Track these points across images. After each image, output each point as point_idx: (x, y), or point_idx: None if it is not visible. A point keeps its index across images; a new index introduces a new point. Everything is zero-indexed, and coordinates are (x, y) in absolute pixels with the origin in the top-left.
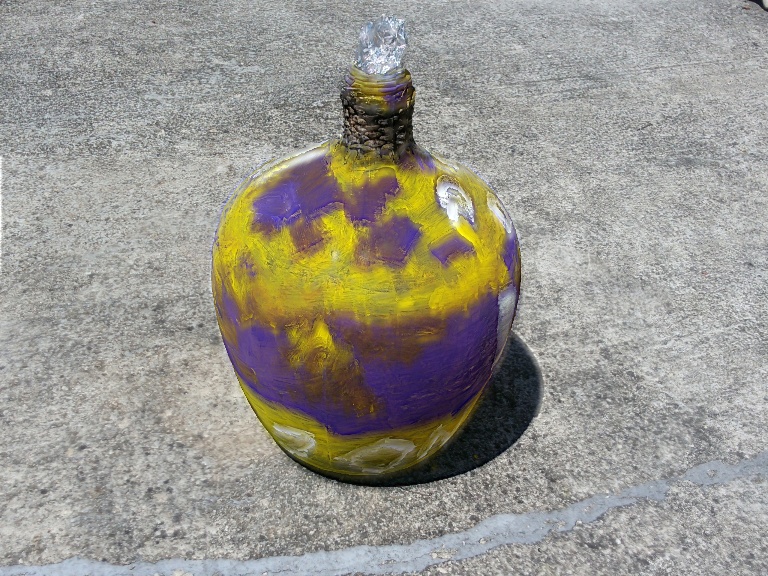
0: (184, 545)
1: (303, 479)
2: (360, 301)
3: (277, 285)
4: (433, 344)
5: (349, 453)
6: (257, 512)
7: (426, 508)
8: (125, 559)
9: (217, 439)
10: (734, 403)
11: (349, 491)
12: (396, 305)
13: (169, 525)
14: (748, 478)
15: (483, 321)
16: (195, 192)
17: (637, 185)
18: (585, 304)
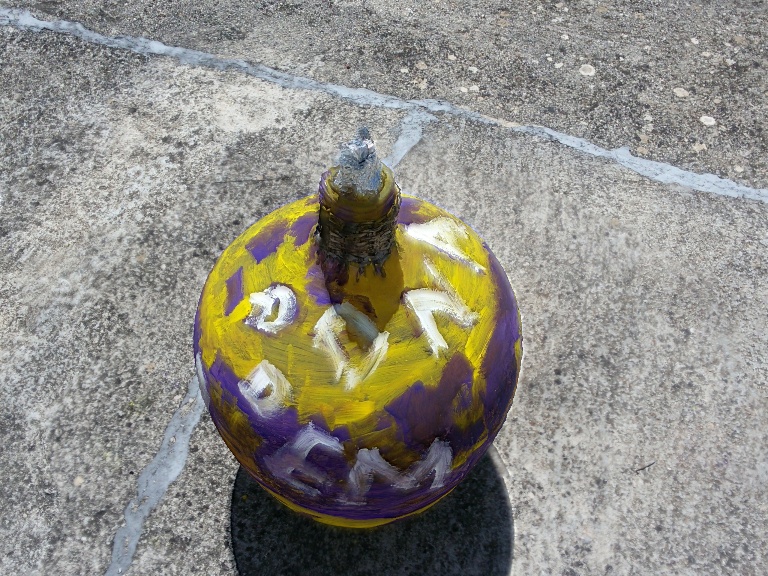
0: None
1: None
2: None
3: None
4: None
5: None
6: None
7: None
8: None
9: None
10: None
11: None
12: None
13: None
14: None
15: None
16: None
17: None
18: None
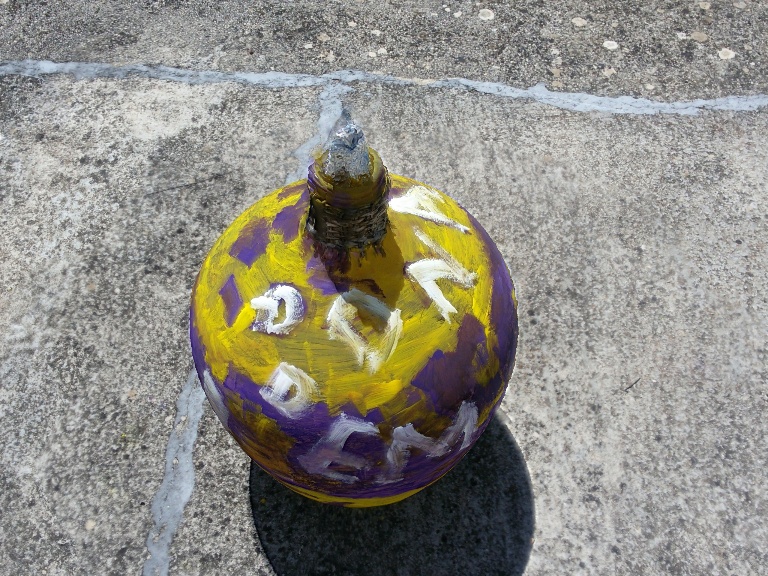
0: None
1: None
2: None
3: None
4: None
5: None
6: None
7: None
8: None
9: None
10: None
11: None
12: None
13: None
14: None
15: None
16: None
17: None
18: None
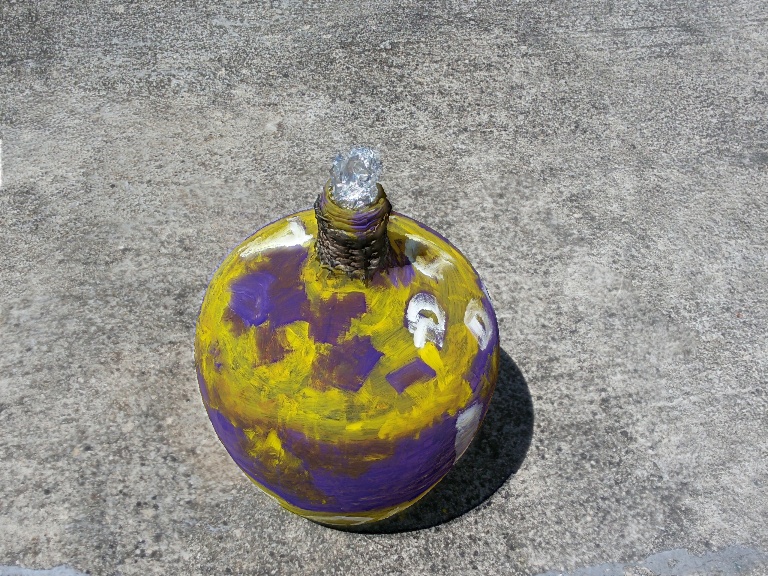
0: (158, 568)
1: (277, 513)
2: (311, 425)
3: (238, 392)
4: (381, 466)
5: (310, 516)
6: (229, 543)
7: (384, 562)
8: (105, 574)
9: (207, 457)
10: (722, 484)
11: (316, 532)
12: (345, 433)
13: (149, 545)
14: (708, 574)
15: (437, 444)
16: (238, 155)
17: (701, 190)
18: (601, 342)
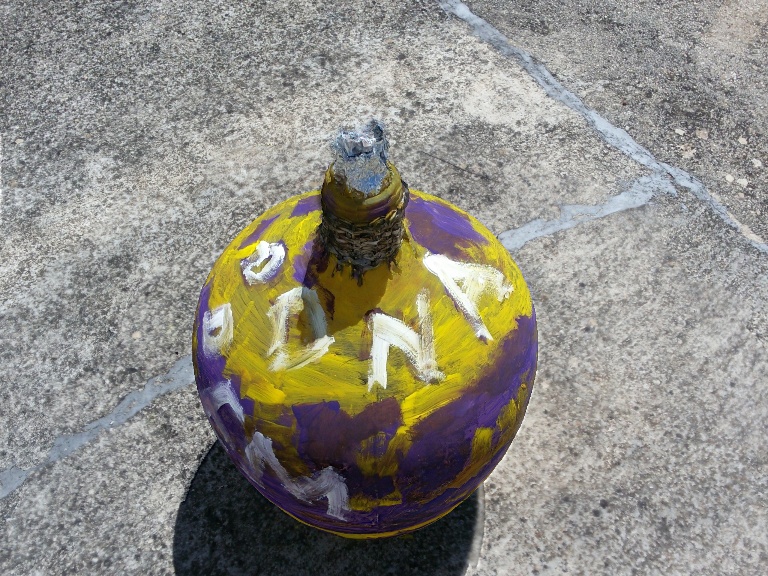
0: None
1: None
2: None
3: None
4: None
5: None
6: None
7: None
8: None
9: None
10: None
11: None
12: None
13: None
14: None
15: None
16: None
17: None
18: None
